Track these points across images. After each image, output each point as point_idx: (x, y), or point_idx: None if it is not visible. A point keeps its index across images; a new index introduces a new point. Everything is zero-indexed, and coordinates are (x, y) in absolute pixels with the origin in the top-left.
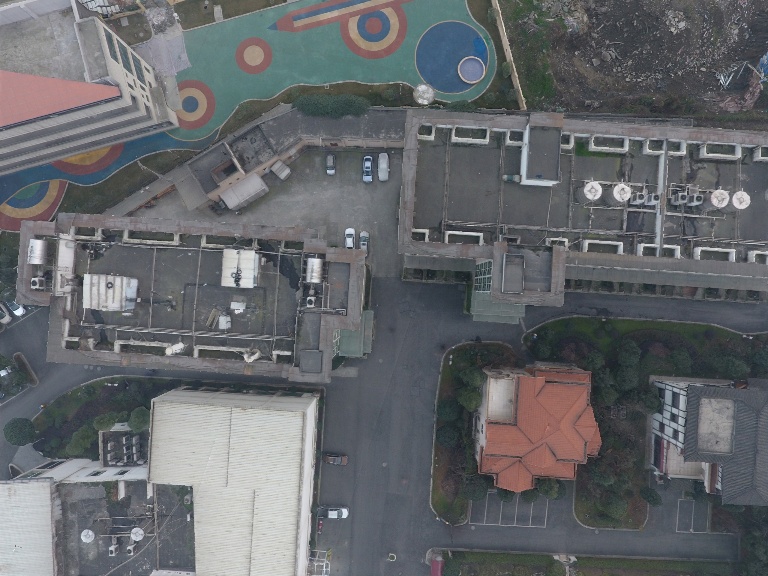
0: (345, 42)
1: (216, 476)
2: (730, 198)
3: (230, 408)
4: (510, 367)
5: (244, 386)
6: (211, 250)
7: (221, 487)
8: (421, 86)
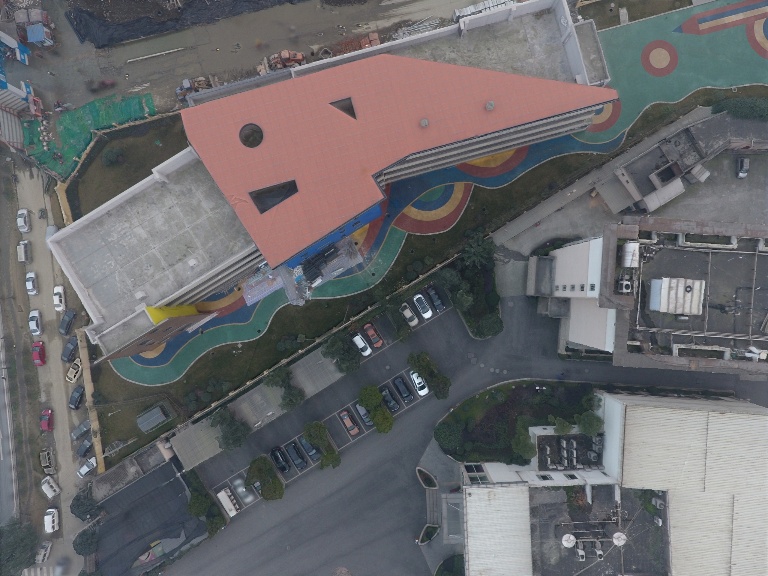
0: (751, 45)
1: (693, 481)
2: None
3: (707, 412)
4: None
5: (658, 390)
6: (766, 254)
7: (698, 492)
8: None
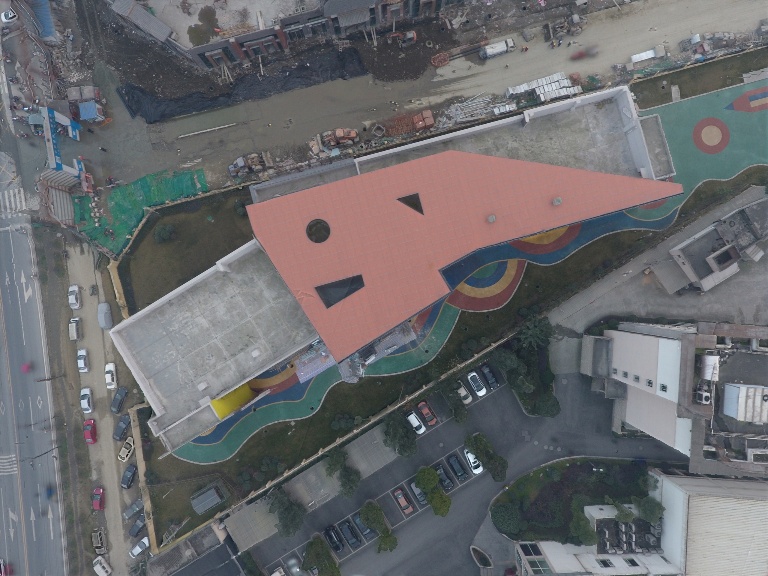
0: None
1: (757, 571)
2: None
3: None
4: None
5: None
6: None
7: None
8: None
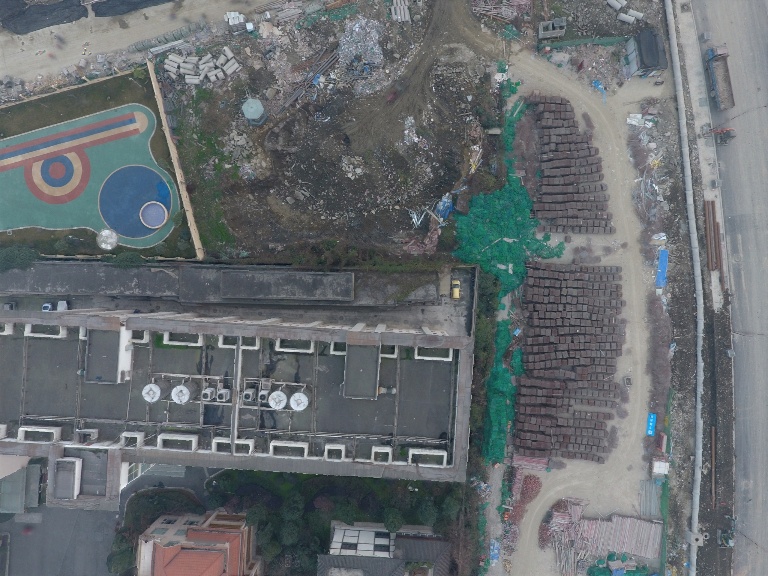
0: (29, 187)
1: None
2: (288, 400)
3: None
4: (191, 513)
5: None
6: None
7: None
8: (105, 231)
